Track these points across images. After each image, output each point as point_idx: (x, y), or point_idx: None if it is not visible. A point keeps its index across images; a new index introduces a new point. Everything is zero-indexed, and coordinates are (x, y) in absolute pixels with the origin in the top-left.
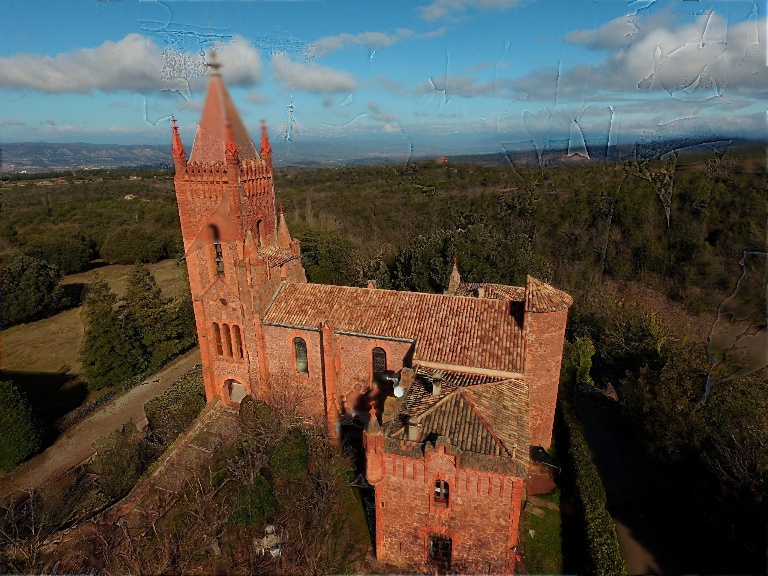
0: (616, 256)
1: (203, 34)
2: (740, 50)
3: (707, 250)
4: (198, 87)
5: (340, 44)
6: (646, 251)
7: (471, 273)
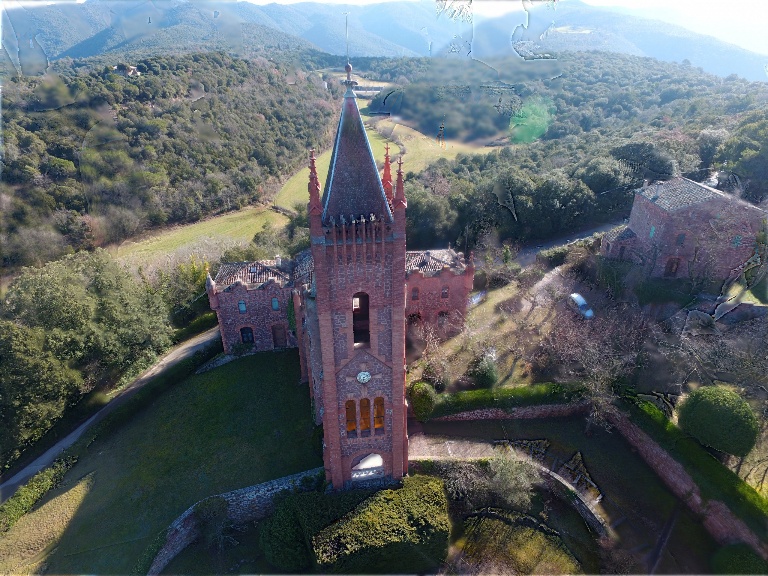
0: (5, 263)
1: (494, 86)
2: (8, 34)
3: (91, 216)
4: (503, 121)
5: (415, 83)
6: (39, 241)
7: (114, 311)
